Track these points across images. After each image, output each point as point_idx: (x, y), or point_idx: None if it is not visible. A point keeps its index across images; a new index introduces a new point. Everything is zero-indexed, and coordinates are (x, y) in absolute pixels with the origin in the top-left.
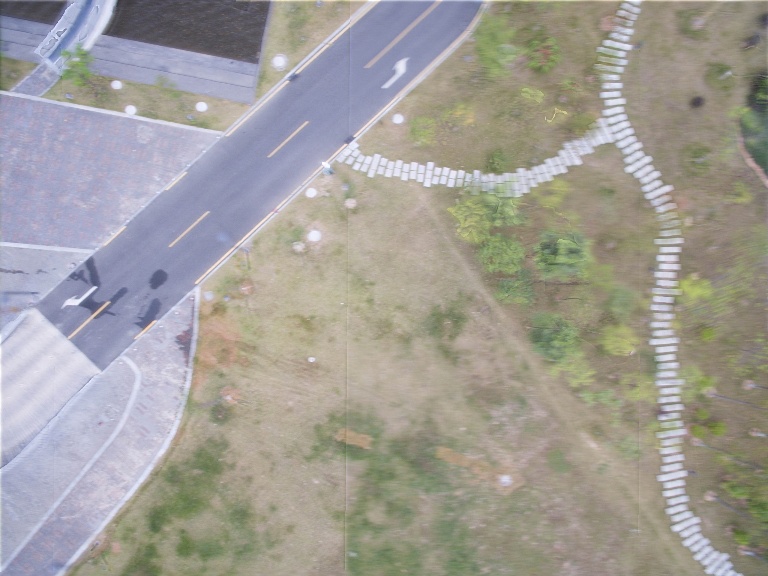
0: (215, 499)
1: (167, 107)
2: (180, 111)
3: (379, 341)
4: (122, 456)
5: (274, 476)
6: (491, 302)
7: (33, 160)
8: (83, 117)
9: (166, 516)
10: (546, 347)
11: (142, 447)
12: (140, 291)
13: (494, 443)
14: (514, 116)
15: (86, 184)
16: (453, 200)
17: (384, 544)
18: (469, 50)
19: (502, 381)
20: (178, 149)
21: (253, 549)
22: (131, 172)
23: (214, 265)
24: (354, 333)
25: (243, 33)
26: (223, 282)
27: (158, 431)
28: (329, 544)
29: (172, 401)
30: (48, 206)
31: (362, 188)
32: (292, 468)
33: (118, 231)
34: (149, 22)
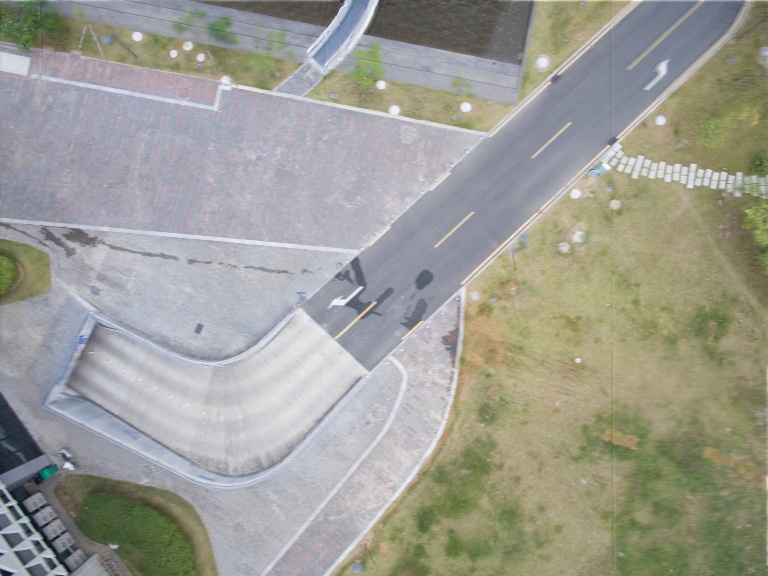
0: (483, 499)
1: (431, 107)
2: (445, 111)
3: (645, 342)
4: (389, 456)
5: (542, 476)
6: (755, 303)
7: (297, 160)
8: (346, 117)
9: (435, 516)
10: None
11: (409, 447)
12: (406, 291)
13: (759, 444)
14: None
15: (350, 184)
16: (716, 202)
17: (652, 544)
18: (731, 52)
19: (767, 382)
20: (442, 149)
21: (522, 549)
22: (395, 172)
23: (480, 266)
24: (620, 334)
25: (504, 34)
26: (489, 283)
27: (425, 431)
28: (598, 544)
29: (439, 401)
30: (313, 206)
31: (626, 189)
32: (560, 468)
33: (383, 231)
34: (410, 22)
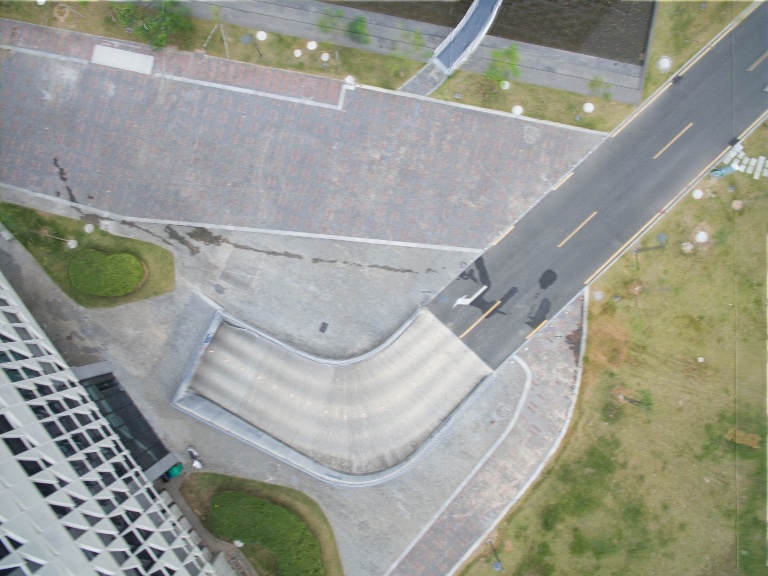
0: (607, 498)
1: (554, 108)
2: (568, 112)
3: (767, 342)
4: (514, 455)
5: (666, 475)
6: None
7: (421, 159)
8: (470, 117)
9: (559, 514)
10: None
11: (533, 446)
12: (530, 291)
13: None
14: None
15: (474, 184)
16: None
17: None
18: None
19: None
20: (565, 150)
21: (647, 547)
22: (519, 172)
23: (603, 265)
24: (743, 333)
25: (625, 35)
26: (612, 282)
27: (549, 430)
28: (721, 542)
29: (563, 400)
30: (437, 205)
31: (748, 190)
32: (683, 467)
33: (507, 231)
34: (532, 23)
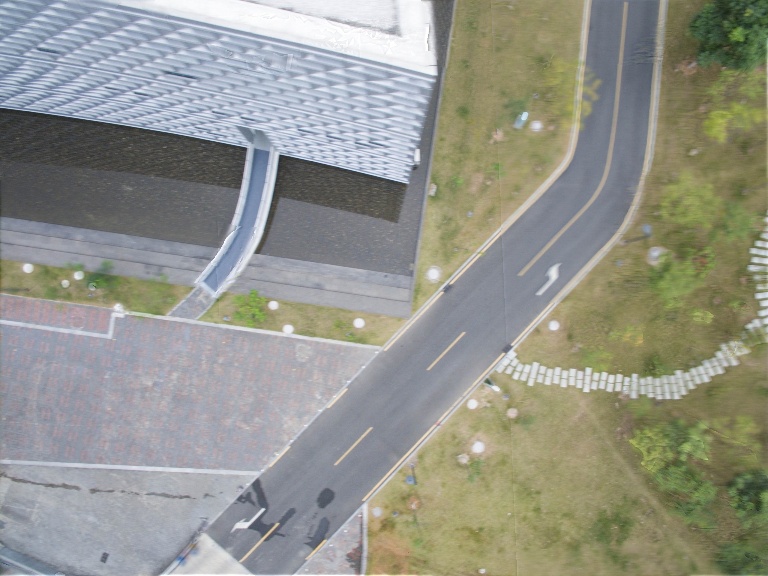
0: None
1: (325, 325)
2: (338, 329)
3: (548, 550)
4: None
5: None
6: (656, 505)
7: (193, 384)
8: (241, 338)
9: None
10: (712, 547)
11: None
12: (308, 511)
13: None
14: (670, 319)
15: (248, 406)
16: (613, 404)
17: None
18: (621, 254)
19: None
20: (337, 366)
21: None
22: (292, 392)
23: (380, 481)
24: (523, 543)
25: (395, 245)
26: (390, 498)
27: None
28: None
29: None
30: (211, 430)
31: (523, 397)
32: None
33: (282, 451)
34: (301, 238)
